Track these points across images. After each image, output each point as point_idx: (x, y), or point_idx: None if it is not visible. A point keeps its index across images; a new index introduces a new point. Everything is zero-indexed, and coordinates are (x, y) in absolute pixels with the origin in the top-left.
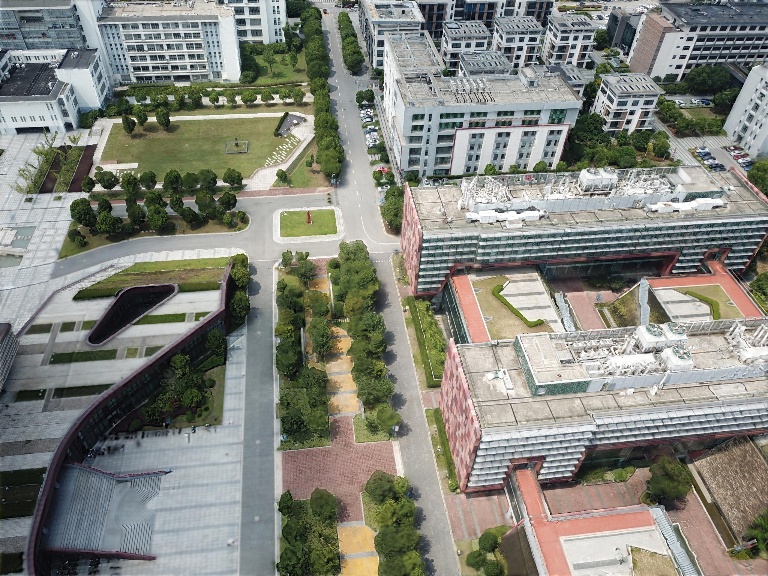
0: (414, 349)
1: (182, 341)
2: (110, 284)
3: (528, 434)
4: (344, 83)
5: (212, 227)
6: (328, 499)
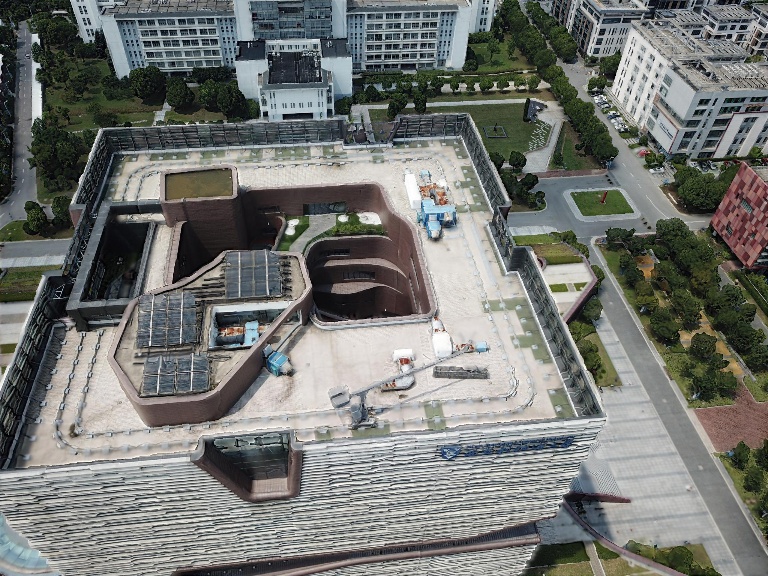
0: (763, 318)
1: None
2: None
3: None
4: None
5: (514, 207)
6: None
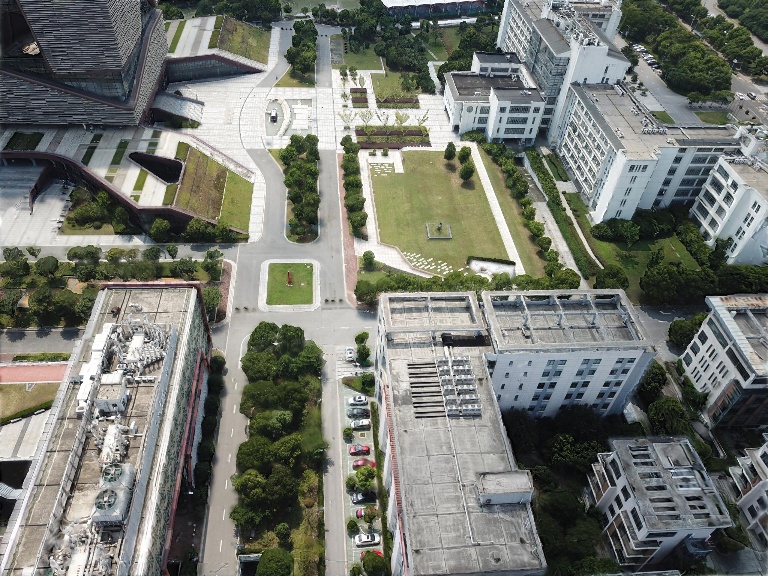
0: None
1: (112, 191)
2: (200, 159)
3: None
4: None
5: None
6: None
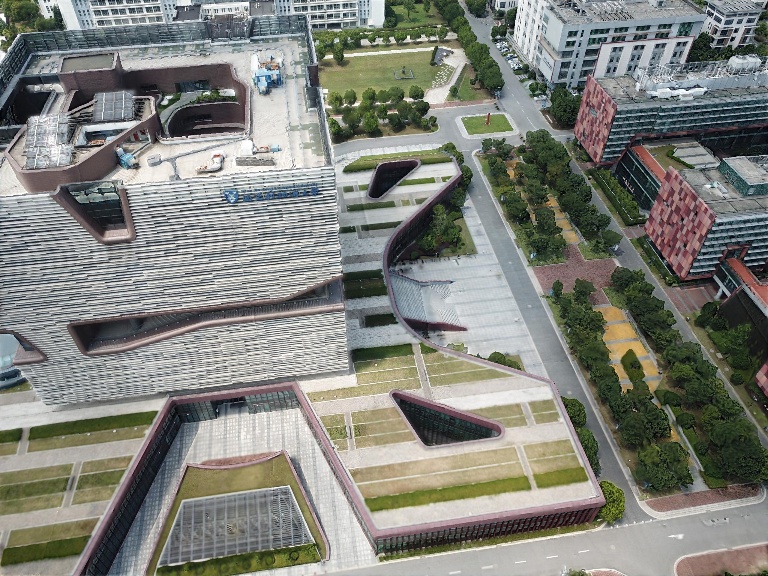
0: (606, 203)
1: (440, 194)
2: None
3: (748, 218)
4: (472, 24)
5: (410, 130)
6: (588, 284)
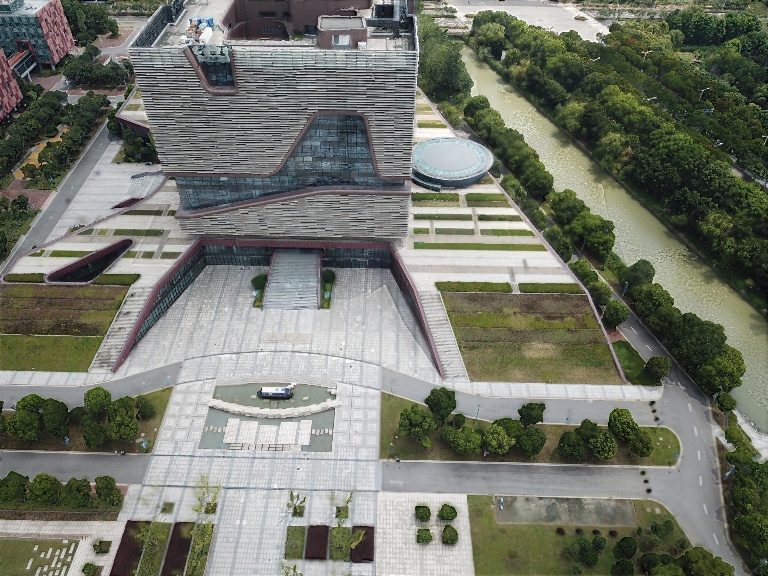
0: None
1: None
2: (108, 300)
3: None
4: None
5: None
6: None
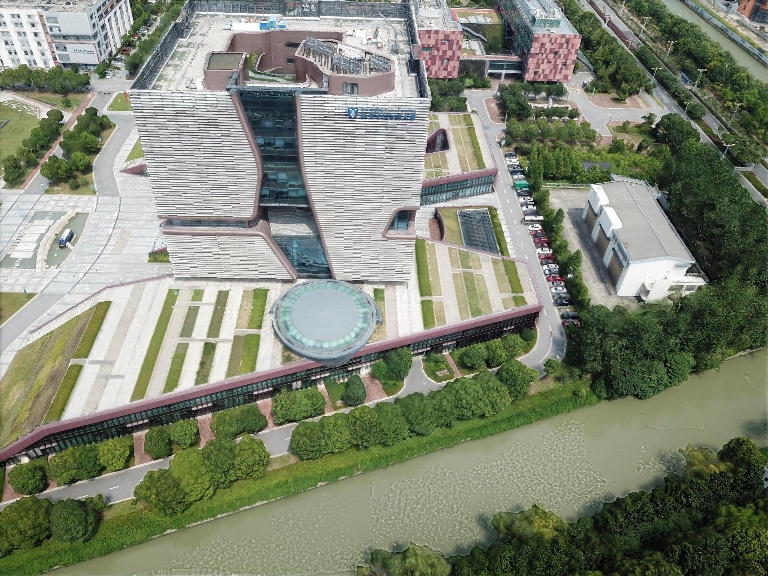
0: None
1: None
2: None
3: None
4: None
5: (104, 134)
6: None
